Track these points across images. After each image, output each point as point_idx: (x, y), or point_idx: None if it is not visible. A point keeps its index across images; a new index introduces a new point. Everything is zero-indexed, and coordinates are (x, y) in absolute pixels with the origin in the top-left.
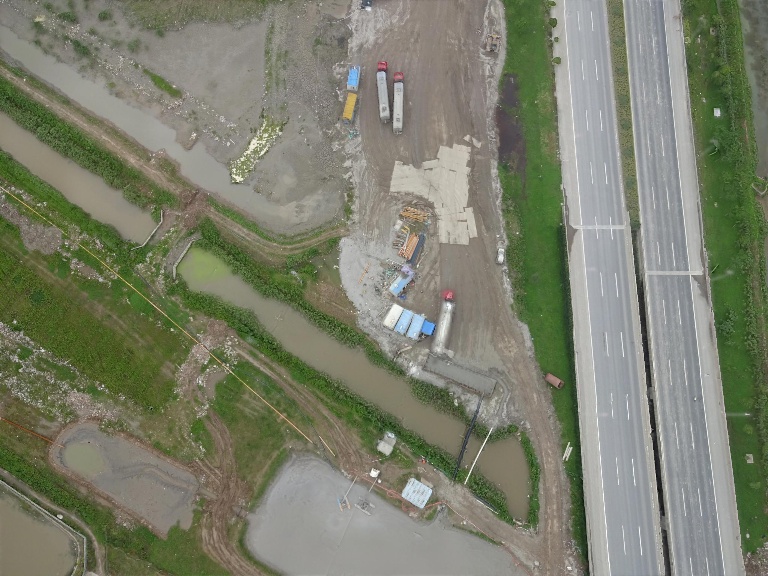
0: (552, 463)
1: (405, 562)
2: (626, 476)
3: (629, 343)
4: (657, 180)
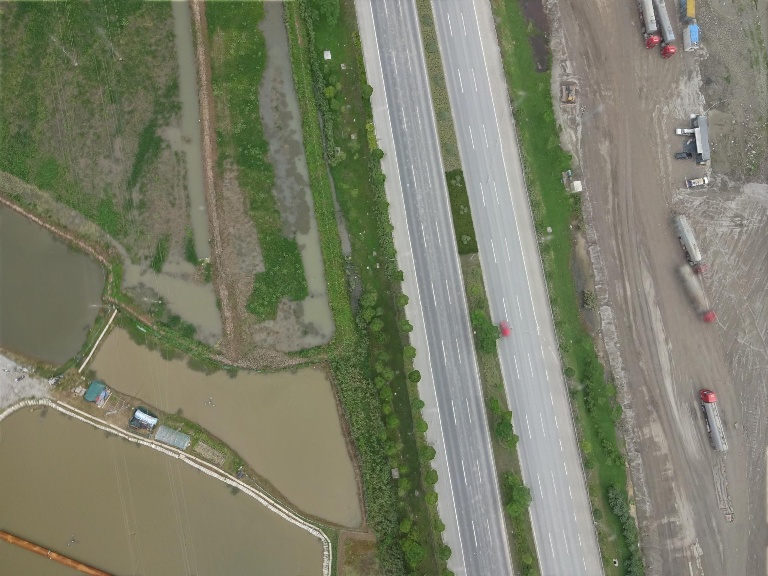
0: None
1: None
2: None
3: None
4: None
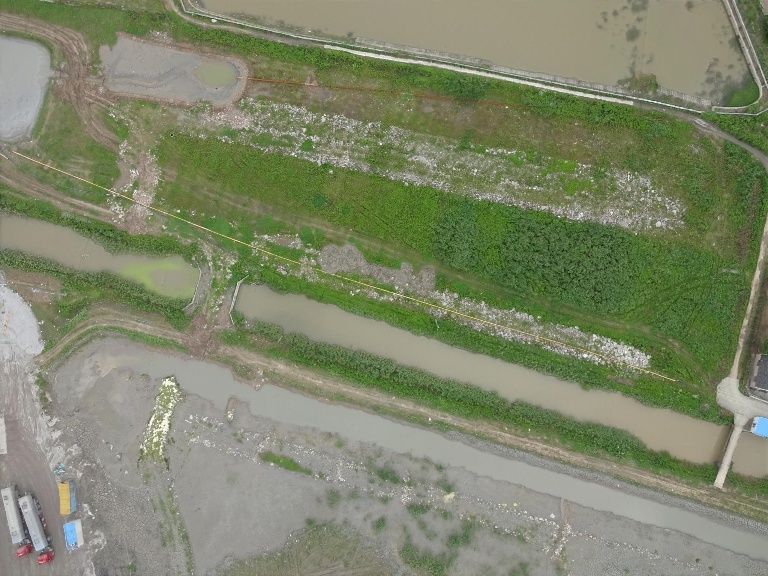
0: None
1: None
2: None
3: None
4: None
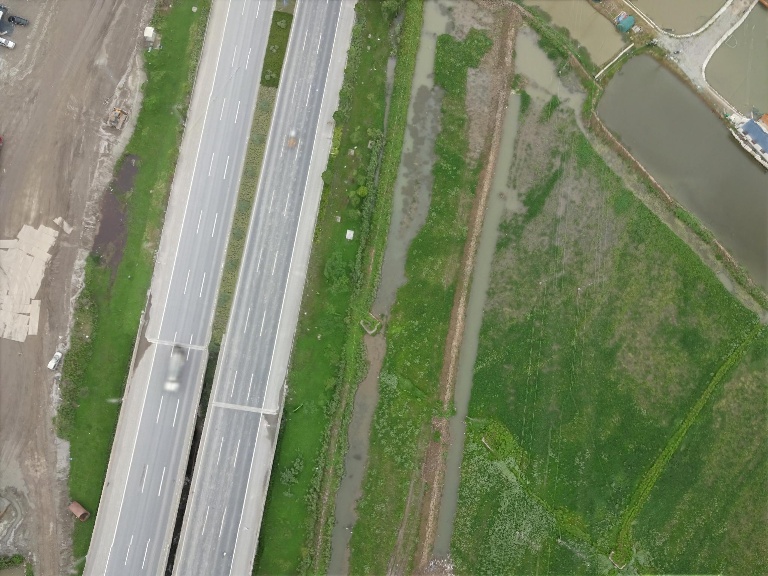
0: None
1: None
2: None
3: (170, 481)
4: (257, 301)
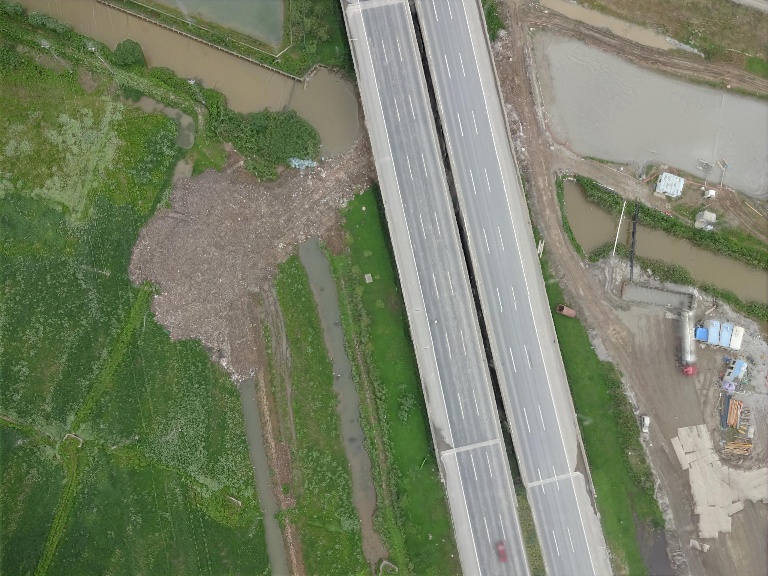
0: (554, 235)
1: (660, 128)
2: (493, 236)
3: (507, 363)
4: (502, 549)
